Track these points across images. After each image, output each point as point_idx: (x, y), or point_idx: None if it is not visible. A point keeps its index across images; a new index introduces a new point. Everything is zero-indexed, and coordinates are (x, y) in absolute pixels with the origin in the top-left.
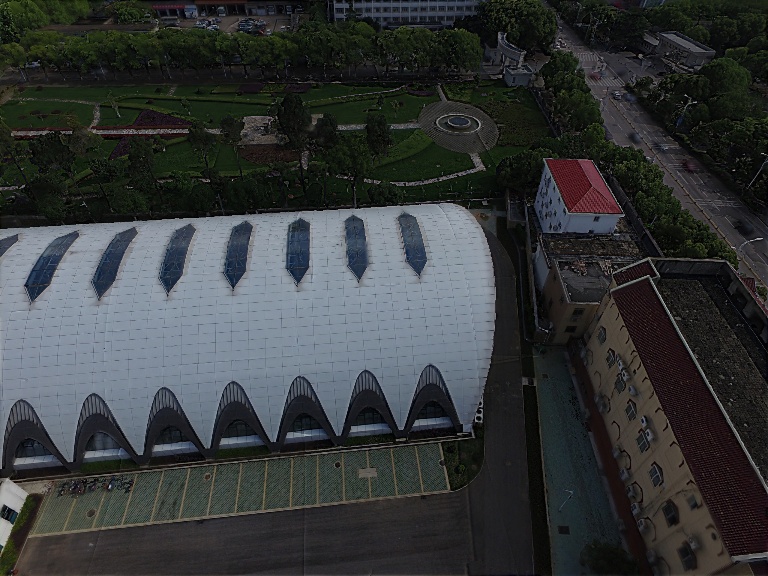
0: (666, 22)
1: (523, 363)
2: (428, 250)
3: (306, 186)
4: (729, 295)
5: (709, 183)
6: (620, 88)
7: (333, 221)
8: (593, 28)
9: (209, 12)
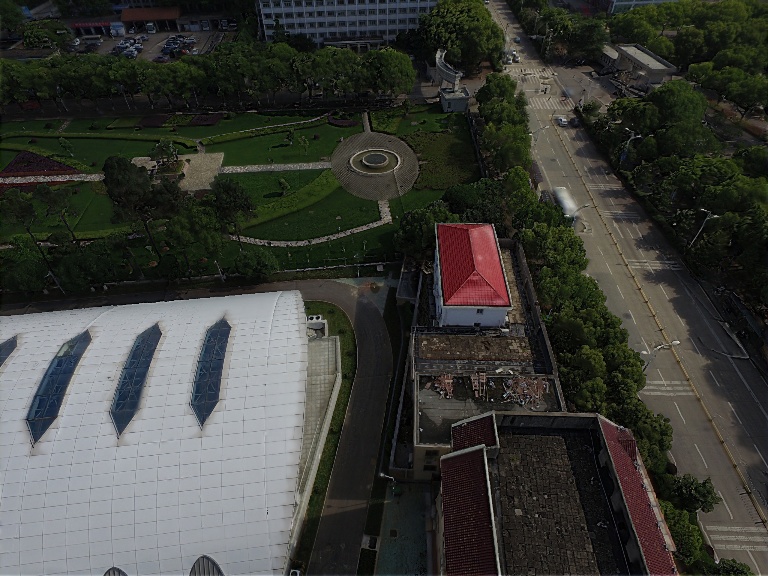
0: (629, 32)
1: (368, 513)
2: (224, 385)
3: (175, 249)
4: (599, 466)
5: (648, 237)
6: (569, 112)
7: (124, 336)
8: (548, 40)
9: (139, 29)
